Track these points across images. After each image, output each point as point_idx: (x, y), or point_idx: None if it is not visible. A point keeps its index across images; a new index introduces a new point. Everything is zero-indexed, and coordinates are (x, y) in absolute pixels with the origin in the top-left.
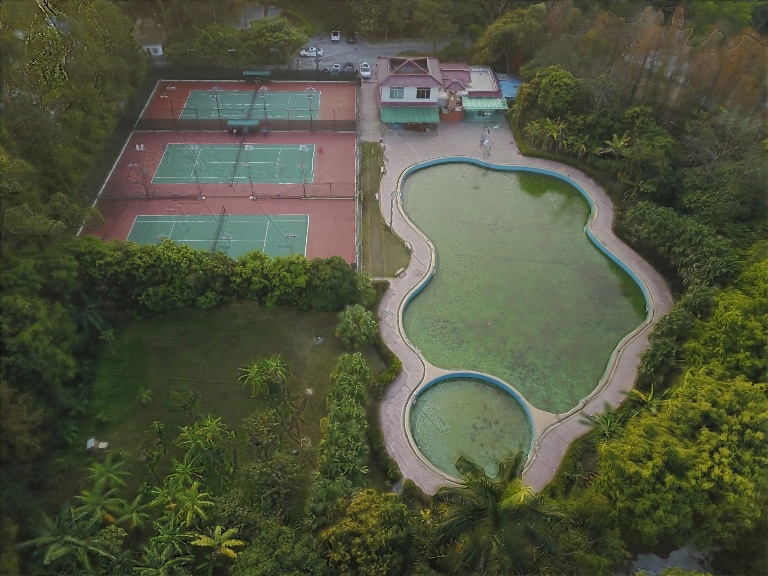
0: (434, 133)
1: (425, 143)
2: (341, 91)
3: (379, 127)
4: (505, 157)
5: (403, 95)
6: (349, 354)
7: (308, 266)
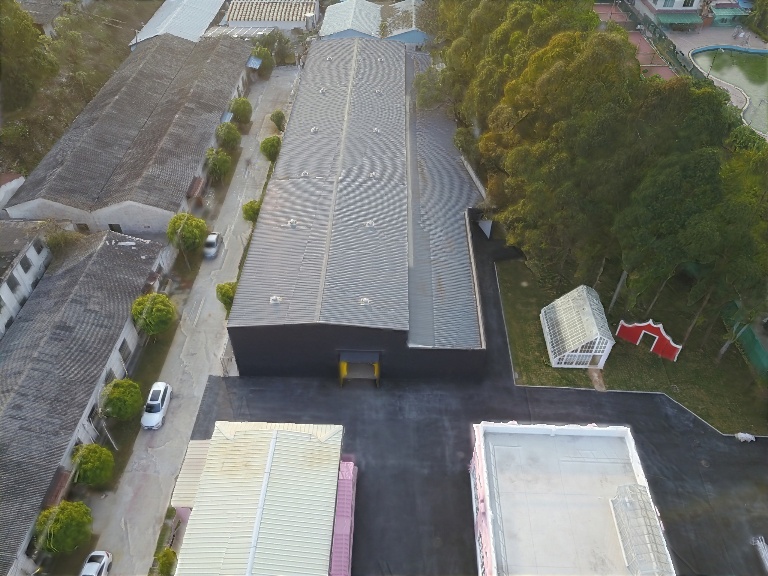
0: (695, 32)
1: (693, 38)
2: (608, 9)
3: (652, 29)
4: (757, 45)
5: (673, 4)
6: (725, 137)
7: (694, 82)
